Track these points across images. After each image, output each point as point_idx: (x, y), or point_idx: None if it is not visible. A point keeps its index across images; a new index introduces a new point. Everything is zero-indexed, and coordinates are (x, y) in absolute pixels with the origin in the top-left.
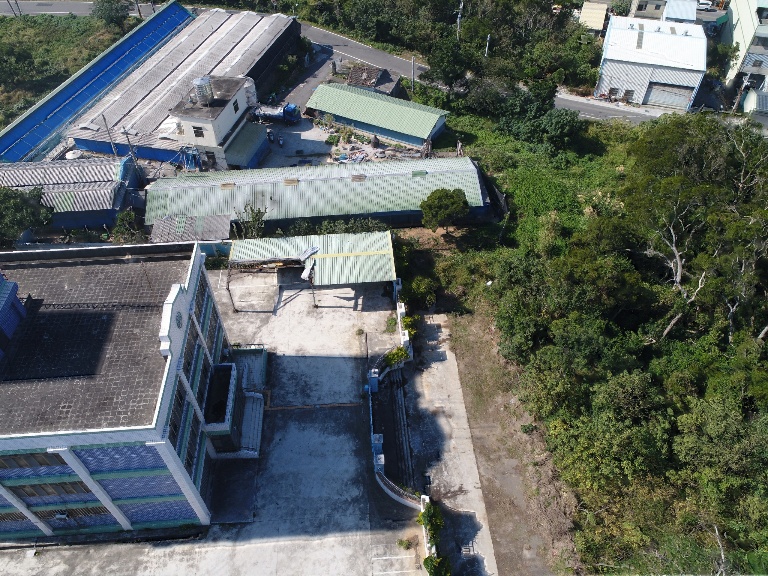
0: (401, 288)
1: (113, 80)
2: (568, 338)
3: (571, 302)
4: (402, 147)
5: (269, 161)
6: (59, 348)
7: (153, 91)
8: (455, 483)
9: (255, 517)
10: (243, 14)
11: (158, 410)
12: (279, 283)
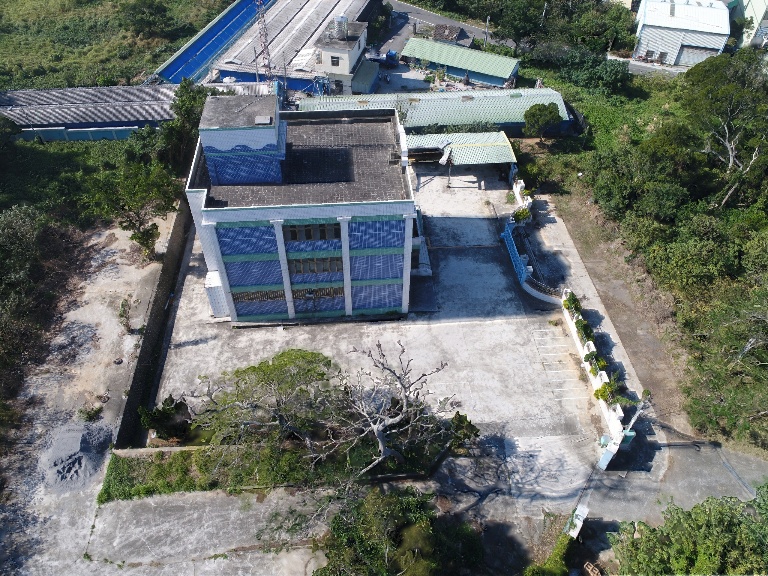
0: (517, 171)
1: (239, 30)
2: (660, 191)
3: (654, 176)
4: None
5: (381, 93)
6: (318, 168)
7: (277, 38)
8: (579, 294)
9: (440, 309)
10: None
11: None
12: (415, 172)
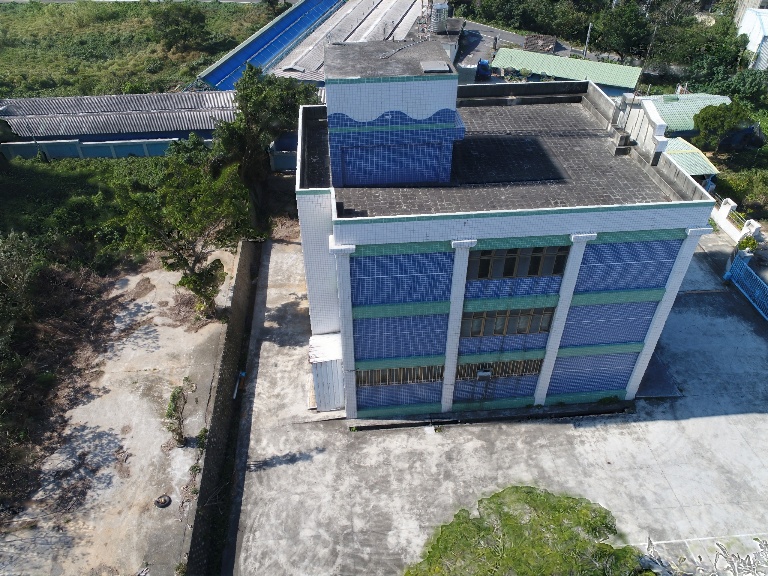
0: (714, 188)
1: (293, 40)
2: None
3: None
4: None
5: None
6: (501, 161)
7: None
8: None
9: (683, 391)
10: None
11: None
12: None
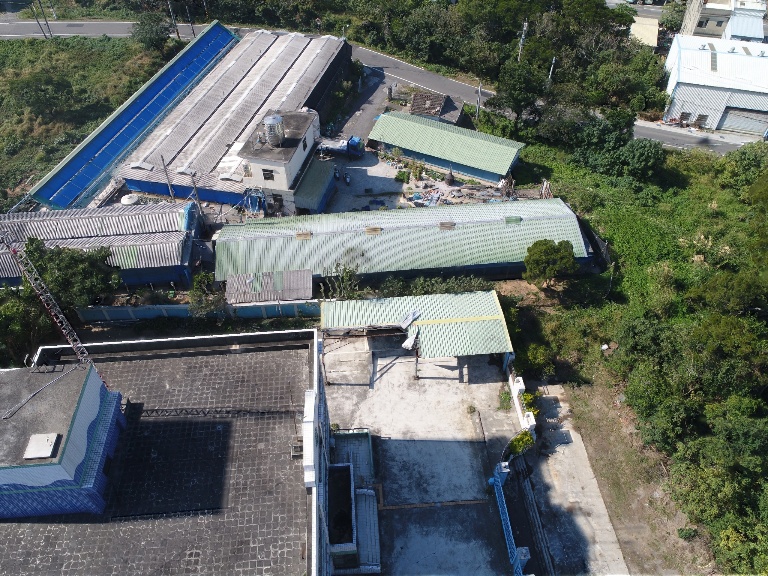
0: (514, 358)
1: (160, 111)
2: (733, 429)
3: (717, 378)
4: (476, 183)
5: (337, 201)
6: (172, 471)
7: (206, 124)
8: None
9: None
10: (291, 36)
11: (315, 567)
12: (371, 349)
